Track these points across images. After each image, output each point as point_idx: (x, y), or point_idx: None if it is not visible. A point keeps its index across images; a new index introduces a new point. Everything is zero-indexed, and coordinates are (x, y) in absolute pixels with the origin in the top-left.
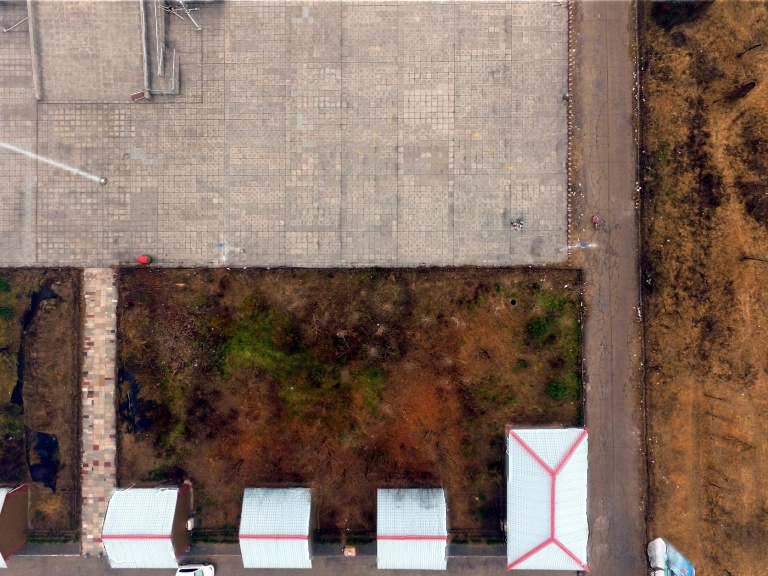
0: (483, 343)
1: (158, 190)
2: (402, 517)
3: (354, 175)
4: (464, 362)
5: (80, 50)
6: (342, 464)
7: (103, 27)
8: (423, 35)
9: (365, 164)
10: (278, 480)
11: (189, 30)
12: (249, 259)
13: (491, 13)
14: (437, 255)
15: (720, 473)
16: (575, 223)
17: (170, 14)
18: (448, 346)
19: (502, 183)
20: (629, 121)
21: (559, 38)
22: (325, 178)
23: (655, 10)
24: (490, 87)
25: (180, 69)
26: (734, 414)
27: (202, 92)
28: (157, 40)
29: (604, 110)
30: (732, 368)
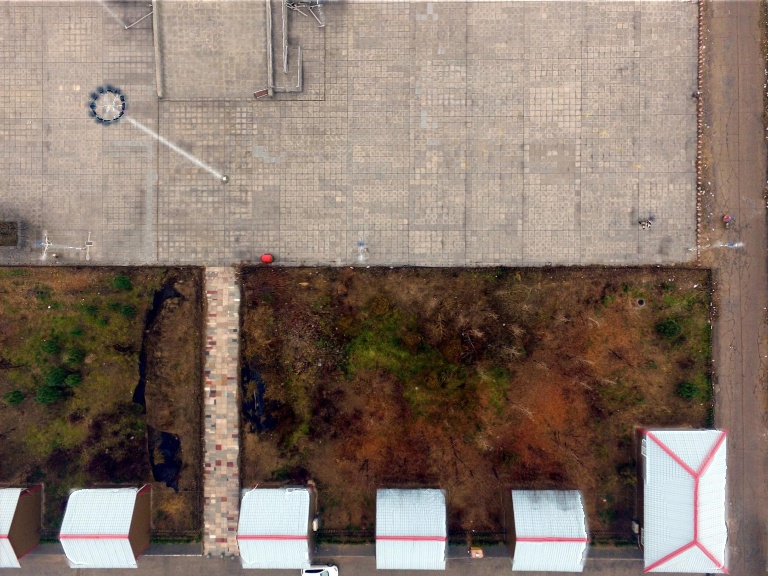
0: (610, 343)
1: (280, 188)
2: (540, 519)
3: (479, 173)
4: (591, 362)
5: (203, 47)
6: (467, 465)
7: (227, 24)
8: (550, 32)
9: (490, 162)
10: (405, 481)
11: (312, 27)
12: (372, 258)
13: (619, 9)
14: (563, 254)
15: None
16: (704, 222)
17: (292, 11)
18: (574, 346)
19: (630, 181)
20: (760, 119)
21: (689, 34)
22: (449, 176)
23: None
24: (618, 84)
25: (303, 66)
26: None
27: (325, 90)
28: (283, 37)
29: (735, 108)
30: None
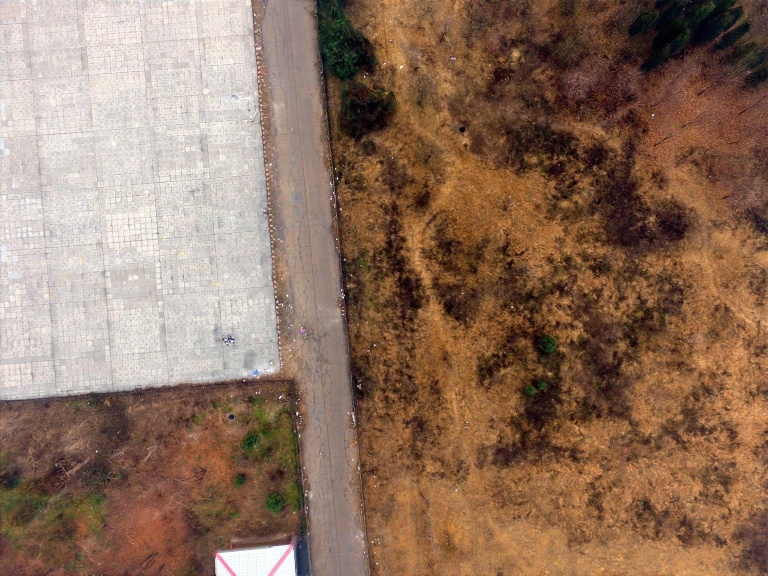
0: (203, 461)
1: None
2: None
3: (63, 303)
4: None
5: None
6: None
7: None
8: (121, 159)
9: (73, 291)
10: None
11: None
12: None
13: (186, 133)
14: (152, 376)
15: (439, 570)
16: (285, 334)
17: None
18: (169, 466)
19: (211, 300)
20: (329, 230)
21: (255, 153)
22: (34, 308)
23: None
24: (191, 206)
25: None
26: (448, 511)
27: None
28: None
29: (304, 221)
30: (444, 466)
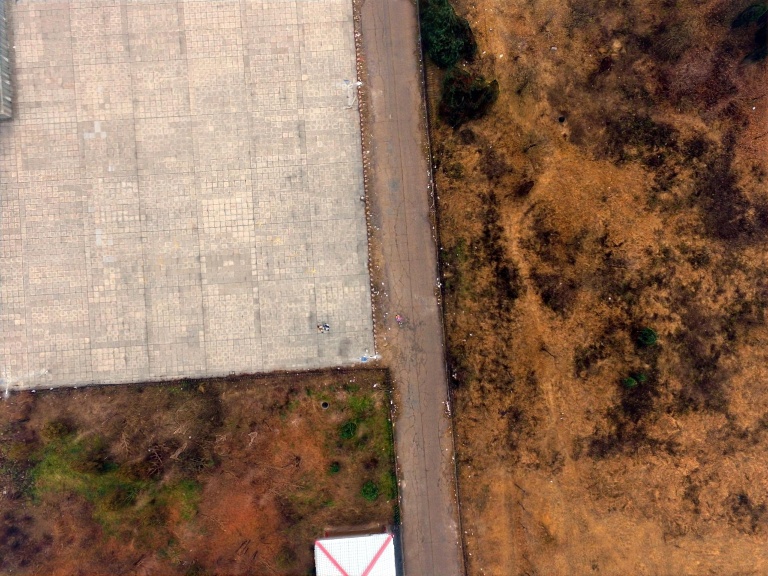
0: (296, 448)
1: None
2: None
3: (157, 288)
4: (278, 469)
5: None
6: None
7: None
8: (218, 144)
9: (168, 276)
10: None
11: None
12: (55, 379)
13: (284, 119)
14: (246, 363)
15: (533, 562)
16: (380, 322)
17: None
18: (262, 453)
19: (306, 287)
20: (426, 219)
21: (352, 140)
22: (128, 292)
23: (441, 110)
24: (288, 192)
25: None
26: (544, 502)
27: None
28: None
29: (401, 209)
30: (539, 456)
